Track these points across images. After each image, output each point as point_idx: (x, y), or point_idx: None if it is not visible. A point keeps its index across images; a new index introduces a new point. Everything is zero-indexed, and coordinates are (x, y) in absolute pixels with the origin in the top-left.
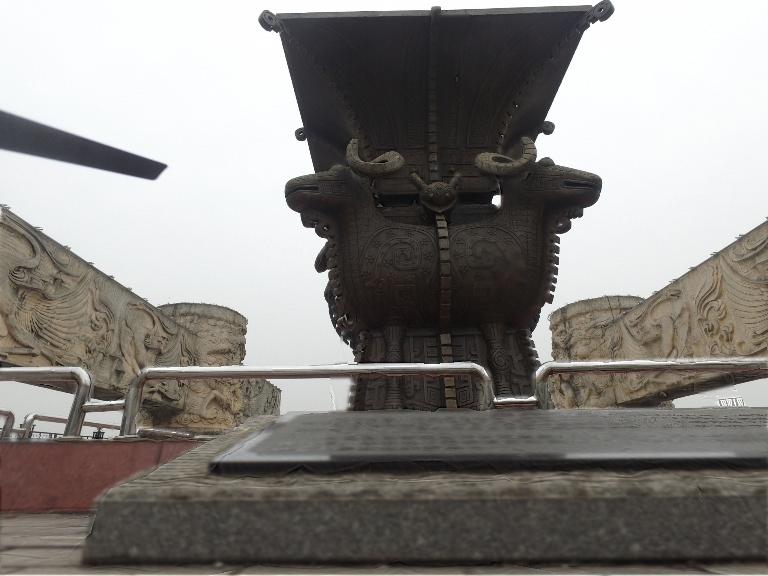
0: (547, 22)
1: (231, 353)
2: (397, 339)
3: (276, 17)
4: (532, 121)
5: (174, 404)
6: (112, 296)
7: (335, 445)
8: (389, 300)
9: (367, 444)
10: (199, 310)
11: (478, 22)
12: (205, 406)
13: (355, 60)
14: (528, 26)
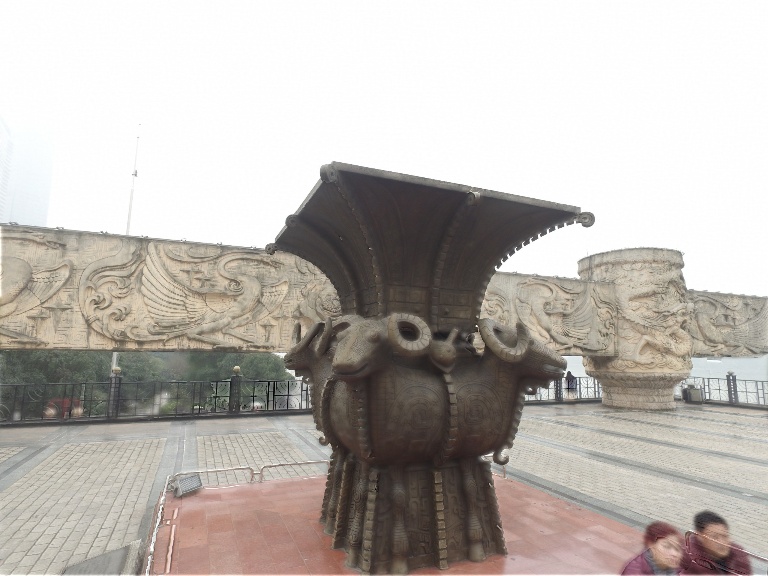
0: (328, 189)
1: (659, 294)
2: (339, 456)
3: None
4: (452, 204)
5: (601, 353)
6: (500, 284)
7: (73, 571)
8: None
9: (76, 573)
10: (611, 258)
11: (310, 208)
12: (637, 352)
13: (307, 247)
14: (326, 196)
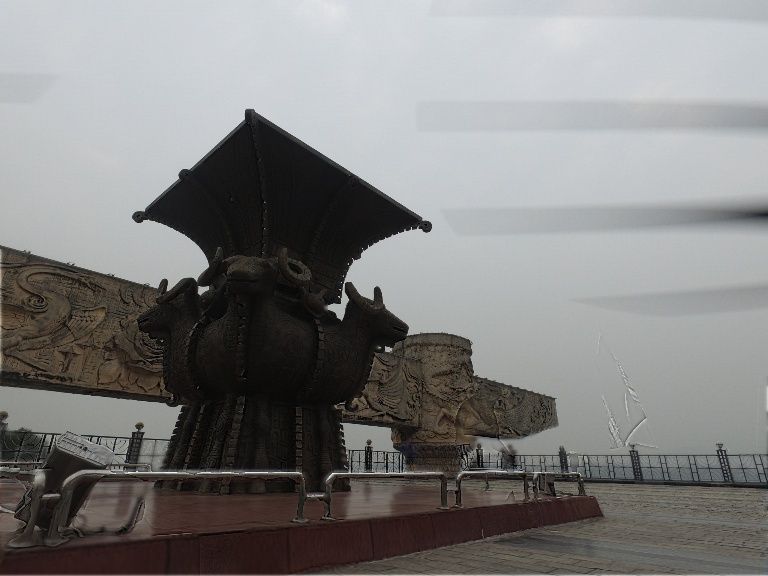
0: (239, 140)
1: (454, 373)
2: (192, 410)
3: None
4: (336, 183)
5: (408, 423)
6: None
7: None
8: (182, 384)
9: None
10: (419, 340)
11: (211, 162)
12: (437, 423)
13: (186, 214)
14: (234, 148)
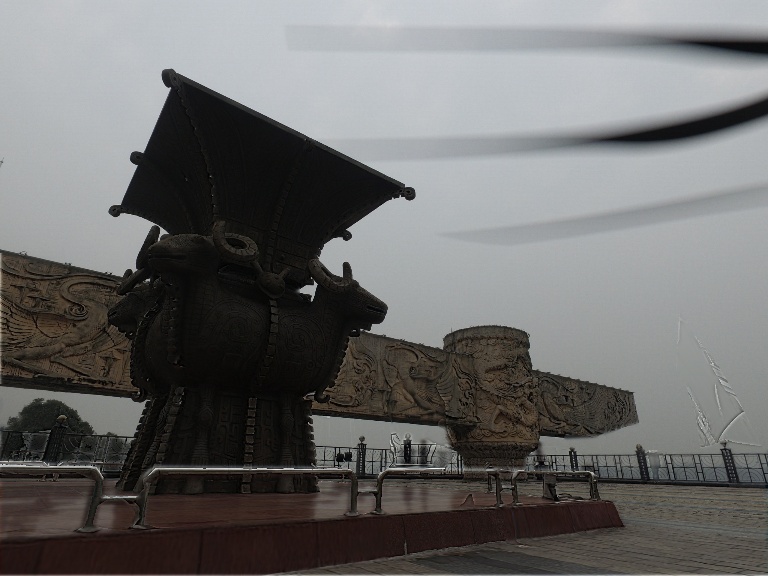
0: (173, 109)
1: (510, 368)
2: (151, 405)
3: (119, 206)
4: (292, 150)
5: (461, 422)
6: (369, 345)
7: None
8: None
9: None
10: (470, 334)
11: (157, 141)
12: (493, 421)
13: (154, 203)
14: (172, 120)
